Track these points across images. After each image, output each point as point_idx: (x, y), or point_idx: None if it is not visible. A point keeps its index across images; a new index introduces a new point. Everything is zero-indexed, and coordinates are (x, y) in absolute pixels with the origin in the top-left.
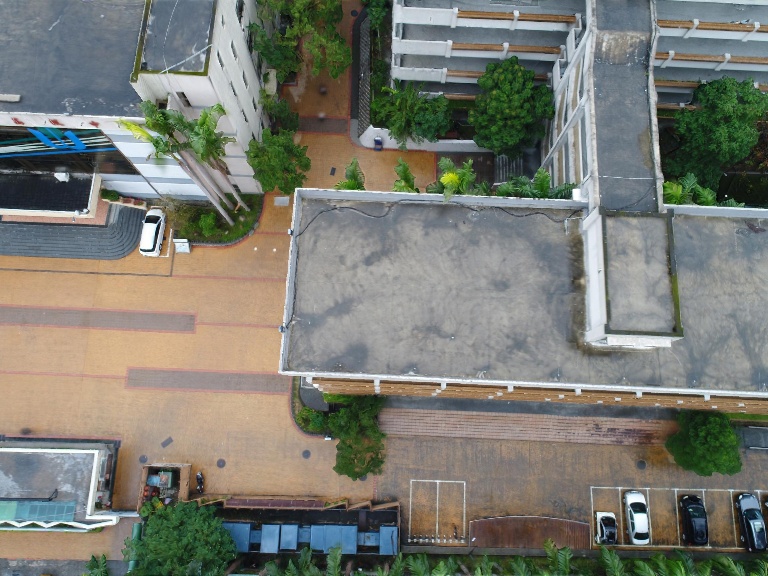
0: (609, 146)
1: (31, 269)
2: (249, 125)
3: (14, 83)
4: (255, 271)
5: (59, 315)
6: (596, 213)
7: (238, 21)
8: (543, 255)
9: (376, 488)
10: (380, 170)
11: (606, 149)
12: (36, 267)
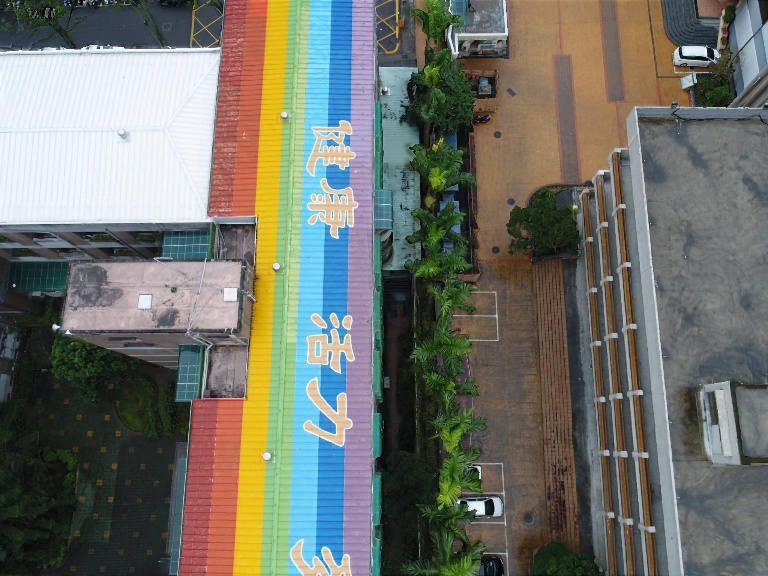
0: None
1: None
2: None
3: None
4: None
5: None
6: None
7: None
8: None
9: (487, 262)
10: None
11: None
12: None
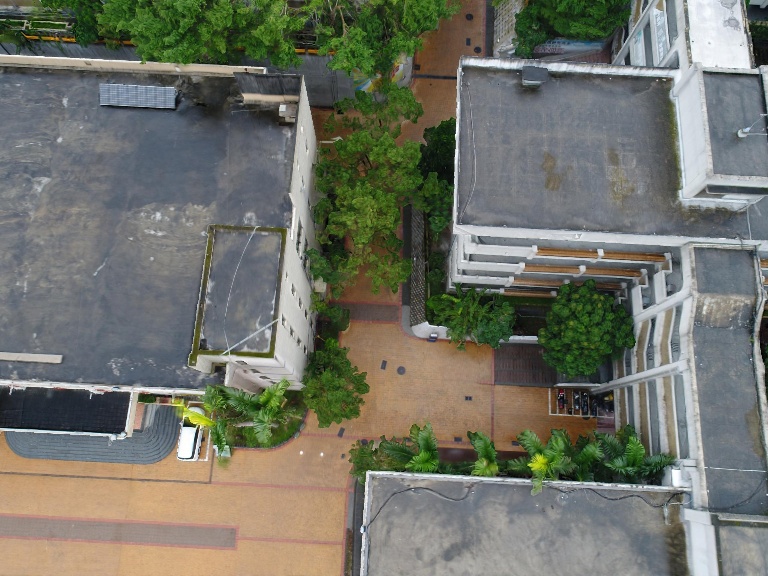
0: (714, 428)
1: (59, 474)
2: (302, 343)
3: (55, 339)
4: (301, 478)
5: (89, 528)
6: (707, 520)
7: (297, 254)
8: (641, 548)
9: None
10: (434, 363)
11: (711, 432)
12: (65, 472)
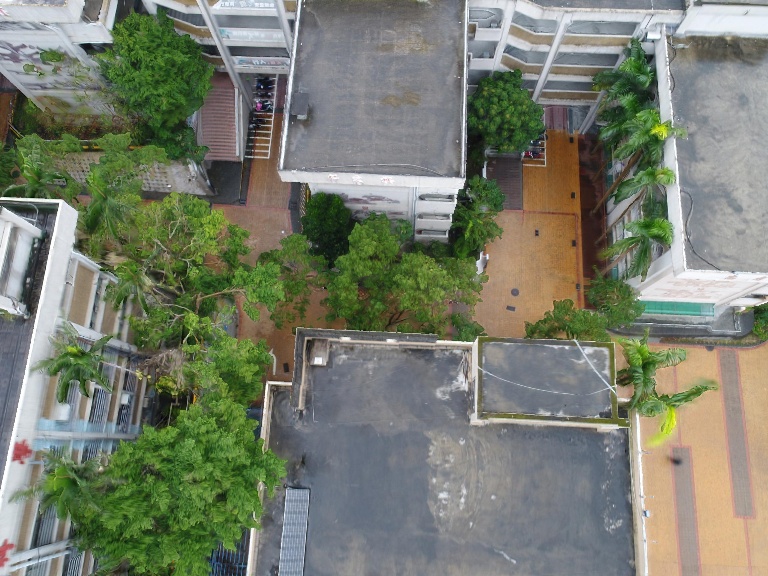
0: (620, 0)
1: None
2: None
3: None
4: None
5: None
6: (697, 10)
7: None
8: (709, 66)
9: None
10: (507, 262)
11: (623, 3)
12: None
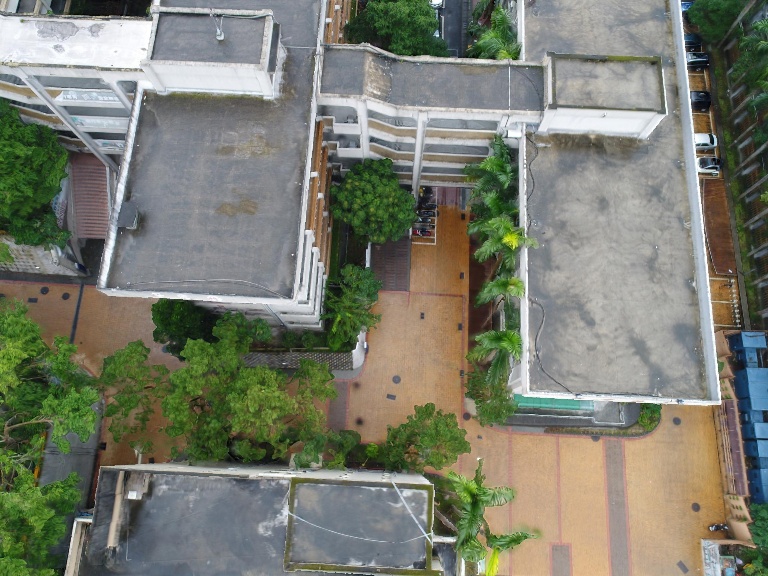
0: (477, 99)
1: None
2: None
3: None
4: (502, 480)
5: None
6: (552, 113)
7: None
8: (571, 167)
9: None
10: (389, 347)
11: (480, 102)
12: None
